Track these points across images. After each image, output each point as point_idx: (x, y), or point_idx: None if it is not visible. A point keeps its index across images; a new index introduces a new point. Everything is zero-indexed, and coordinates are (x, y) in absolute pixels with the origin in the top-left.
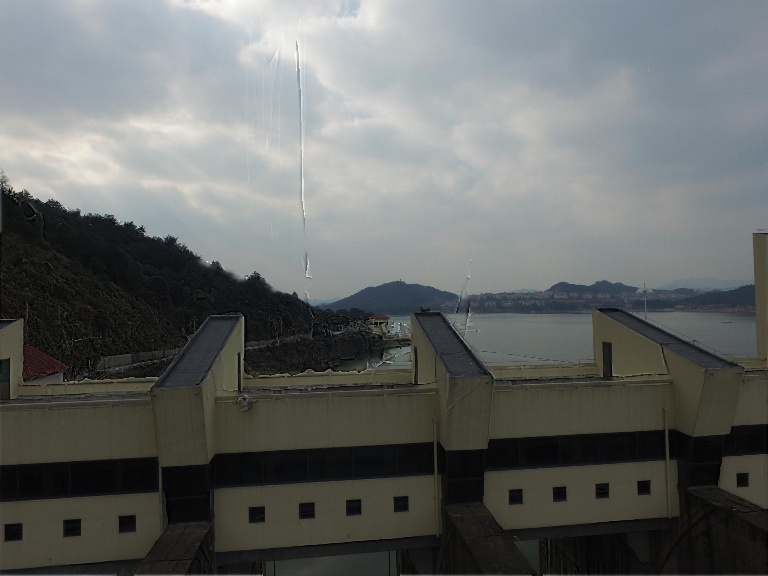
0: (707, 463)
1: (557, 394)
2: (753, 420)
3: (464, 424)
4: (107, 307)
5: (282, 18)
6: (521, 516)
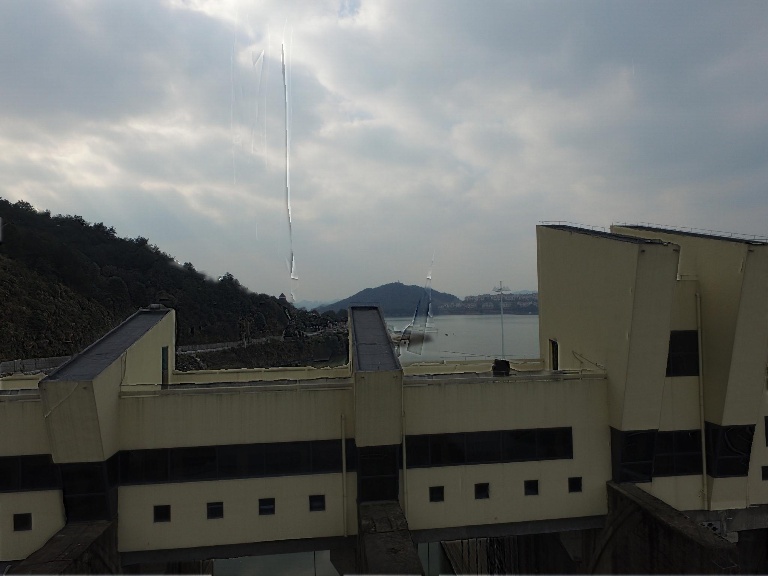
0: (381, 476)
1: (215, 400)
2: (451, 428)
3: (69, 434)
4: (47, 308)
5: (268, 19)
6: (168, 535)
